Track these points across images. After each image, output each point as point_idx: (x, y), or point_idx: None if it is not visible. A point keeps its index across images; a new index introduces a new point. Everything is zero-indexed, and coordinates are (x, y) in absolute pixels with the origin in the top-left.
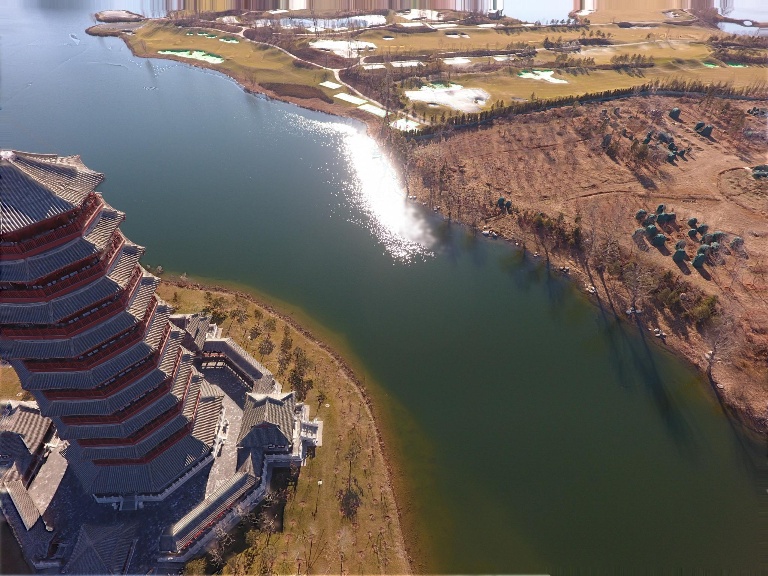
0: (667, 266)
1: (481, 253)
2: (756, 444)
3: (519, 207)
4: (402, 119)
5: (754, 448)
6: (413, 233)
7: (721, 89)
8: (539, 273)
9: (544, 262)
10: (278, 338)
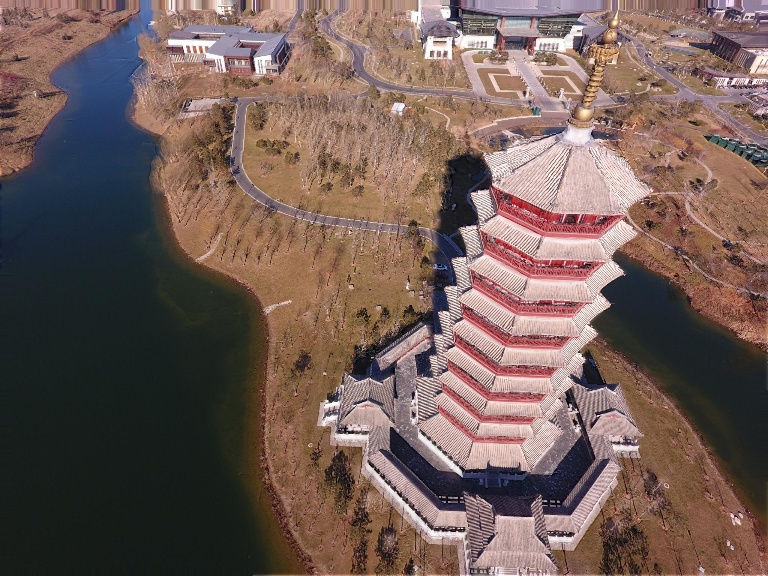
0: None
1: None
2: None
3: None
4: None
5: None
6: None
7: None
8: None
9: None
10: (373, 573)
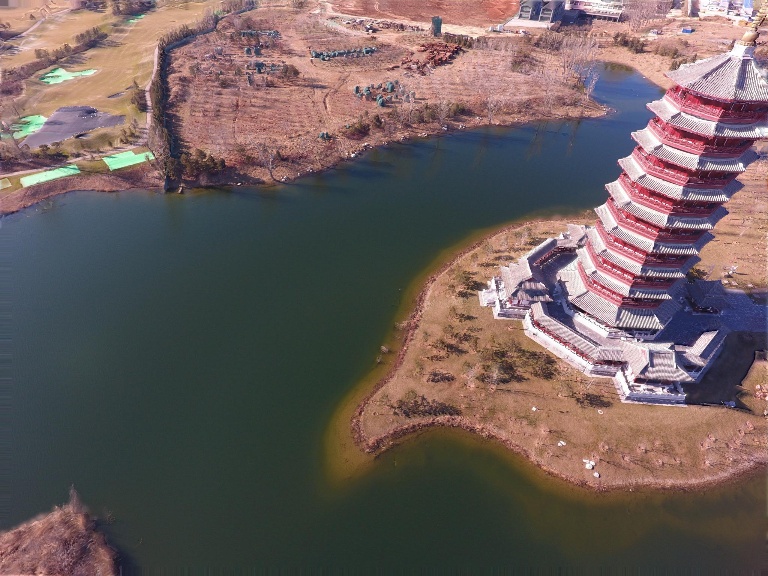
0: None
1: None
2: None
3: (330, 133)
4: (105, 159)
5: None
6: (344, 187)
7: (194, 29)
8: (405, 147)
9: (393, 143)
10: (489, 255)
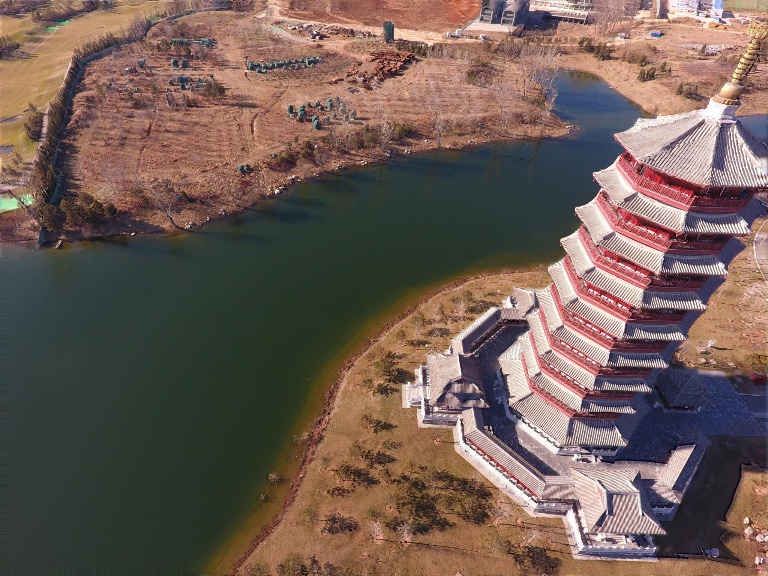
0: (353, 127)
1: (306, 200)
2: (484, 150)
3: (253, 164)
4: None
5: (486, 151)
6: (260, 234)
7: (119, 37)
8: (340, 179)
9: (326, 174)
10: (422, 328)
